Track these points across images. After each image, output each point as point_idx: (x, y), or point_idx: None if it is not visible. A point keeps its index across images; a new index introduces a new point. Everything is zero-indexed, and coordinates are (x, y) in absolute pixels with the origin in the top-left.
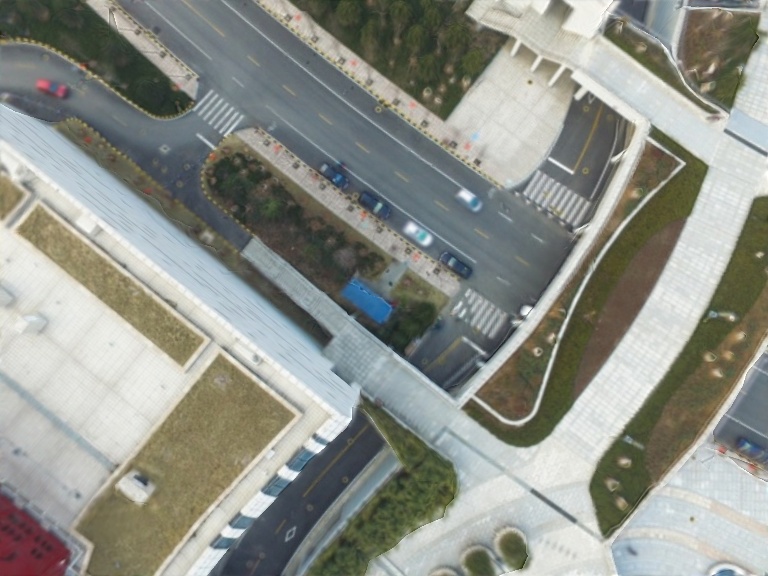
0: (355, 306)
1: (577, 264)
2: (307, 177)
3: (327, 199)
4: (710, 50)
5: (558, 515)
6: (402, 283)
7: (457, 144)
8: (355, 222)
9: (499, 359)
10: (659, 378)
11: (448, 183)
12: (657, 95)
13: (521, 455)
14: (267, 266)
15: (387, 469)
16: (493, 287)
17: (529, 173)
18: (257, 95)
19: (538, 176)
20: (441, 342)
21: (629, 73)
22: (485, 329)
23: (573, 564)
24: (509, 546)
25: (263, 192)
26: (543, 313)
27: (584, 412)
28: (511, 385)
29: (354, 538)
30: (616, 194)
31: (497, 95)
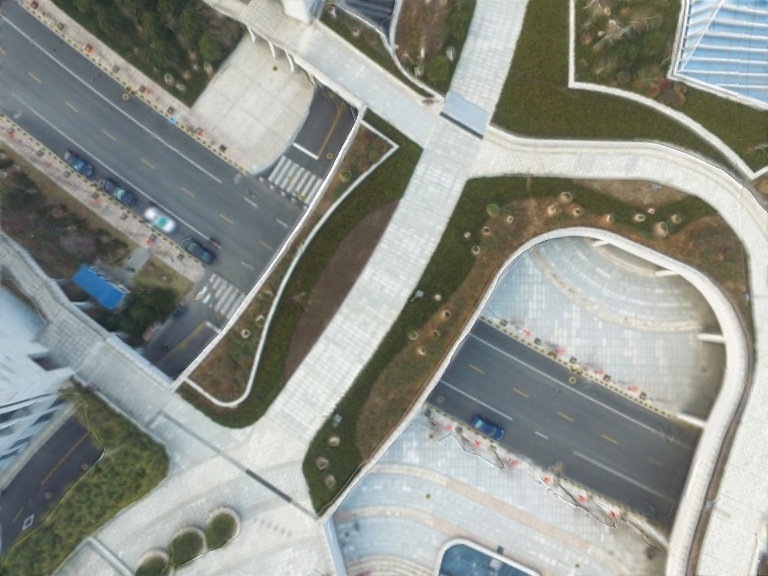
0: (87, 292)
1: (286, 246)
2: (52, 165)
3: (72, 187)
4: (425, 35)
5: (273, 494)
6: (145, 269)
7: (203, 130)
8: (99, 209)
9: (212, 342)
10: (368, 357)
11: (194, 169)
12: (375, 79)
13: (236, 436)
14: (2, 254)
15: (103, 453)
16: (238, 272)
17: (274, 159)
18: (3, 83)
19: (283, 161)
20: (184, 327)
21: (347, 58)
22: (229, 314)
23: (288, 542)
24: (217, 526)
25: (3, 180)
26: (252, 295)
27: (297, 392)
28: (222, 367)
29: (52, 522)
30: (328, 177)
31: (242, 81)
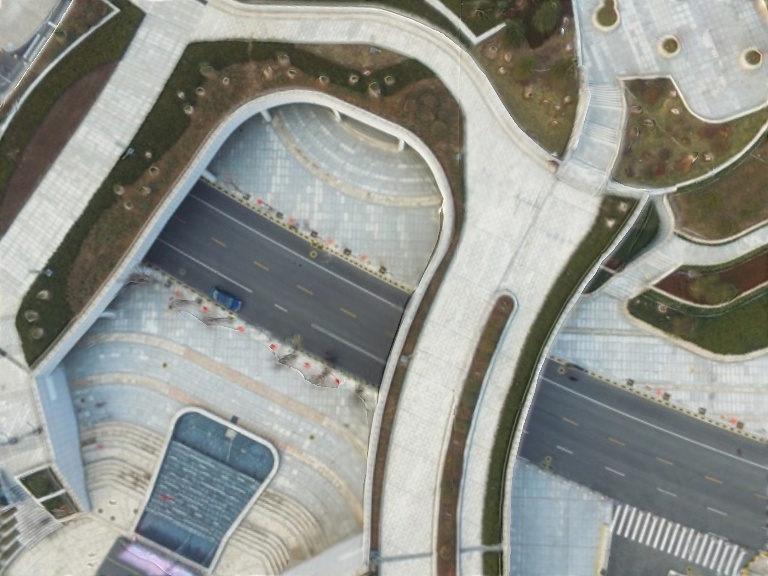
0: None
1: (2, 104)
2: None
3: None
4: None
5: None
6: None
7: None
8: None
9: None
10: (80, 213)
11: None
12: None
13: None
14: None
15: None
16: None
17: (30, 37)
18: None
19: (38, 39)
20: None
21: None
22: None
23: (2, 395)
24: None
25: None
26: None
27: (12, 248)
28: None
29: None
30: None
31: None
